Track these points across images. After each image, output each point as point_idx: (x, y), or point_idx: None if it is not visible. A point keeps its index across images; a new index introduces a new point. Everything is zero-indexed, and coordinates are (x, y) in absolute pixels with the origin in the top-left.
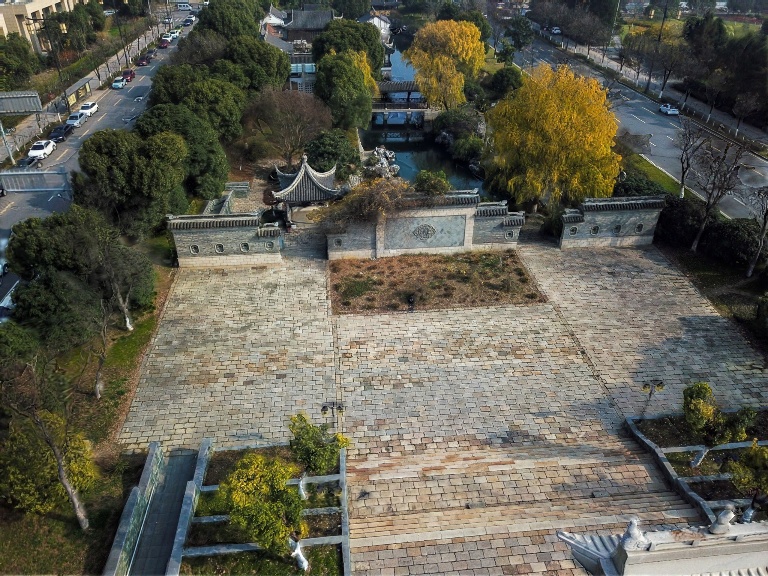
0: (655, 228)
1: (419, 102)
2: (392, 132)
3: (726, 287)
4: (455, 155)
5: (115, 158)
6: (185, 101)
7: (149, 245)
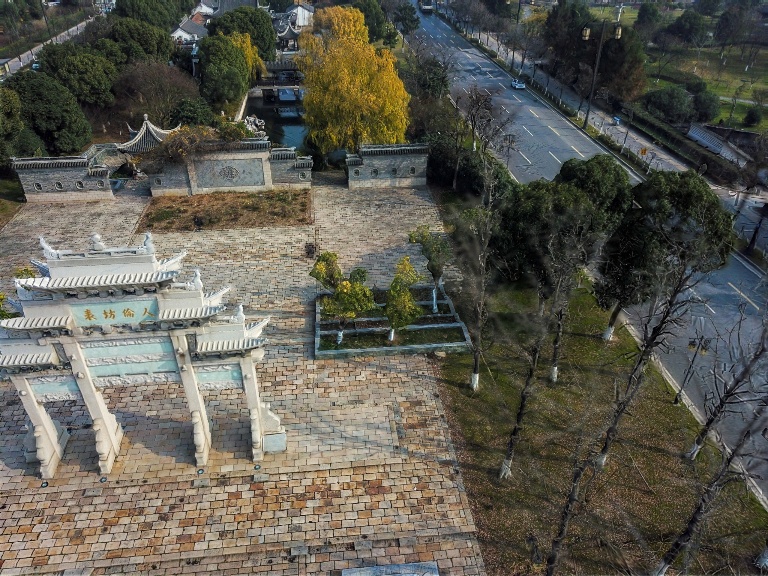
0: (426, 171)
1: None
2: (282, 107)
3: None
4: None
5: None
6: (59, 72)
7: (10, 187)
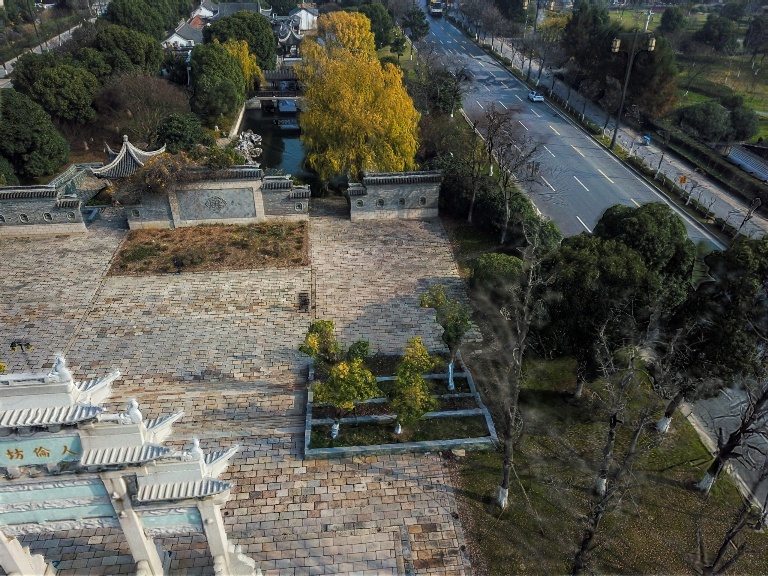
0: (438, 201)
1: None
2: (282, 119)
3: (477, 253)
4: None
5: None
6: (34, 86)
7: None
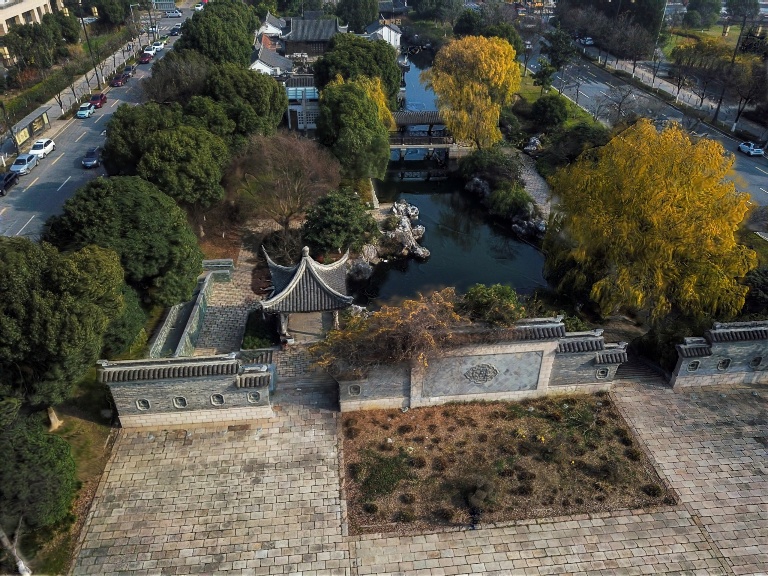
0: None
1: (443, 136)
2: (410, 171)
3: None
4: (493, 210)
5: (6, 293)
6: (146, 159)
7: (84, 381)
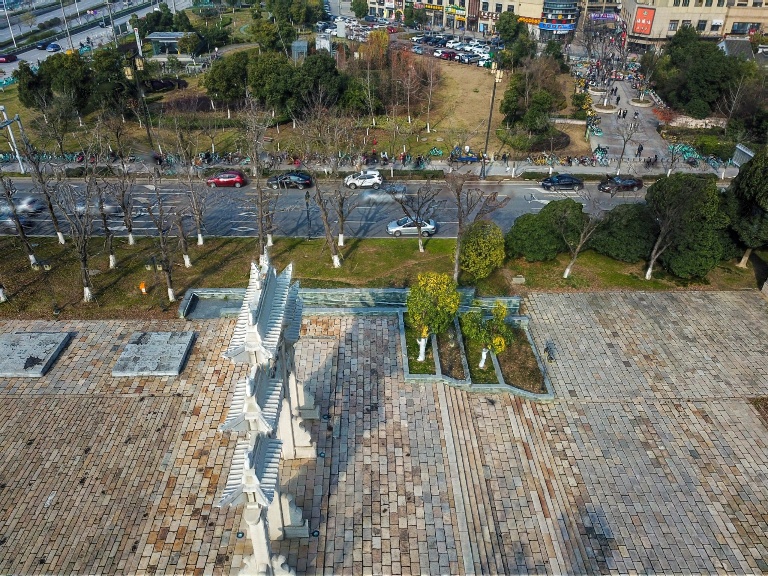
0: None
1: None
2: None
3: None
4: None
5: None
6: None
7: None
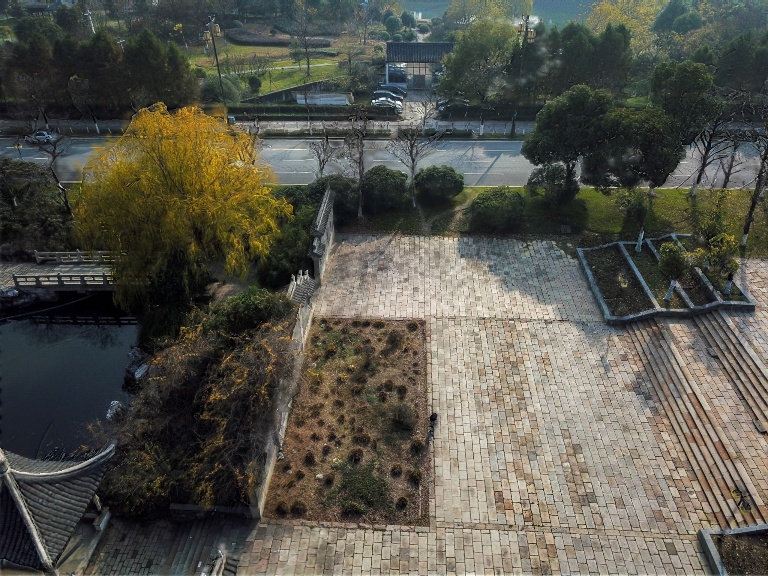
0: (333, 218)
1: None
2: None
3: (424, 221)
4: None
5: None
6: None
7: None
